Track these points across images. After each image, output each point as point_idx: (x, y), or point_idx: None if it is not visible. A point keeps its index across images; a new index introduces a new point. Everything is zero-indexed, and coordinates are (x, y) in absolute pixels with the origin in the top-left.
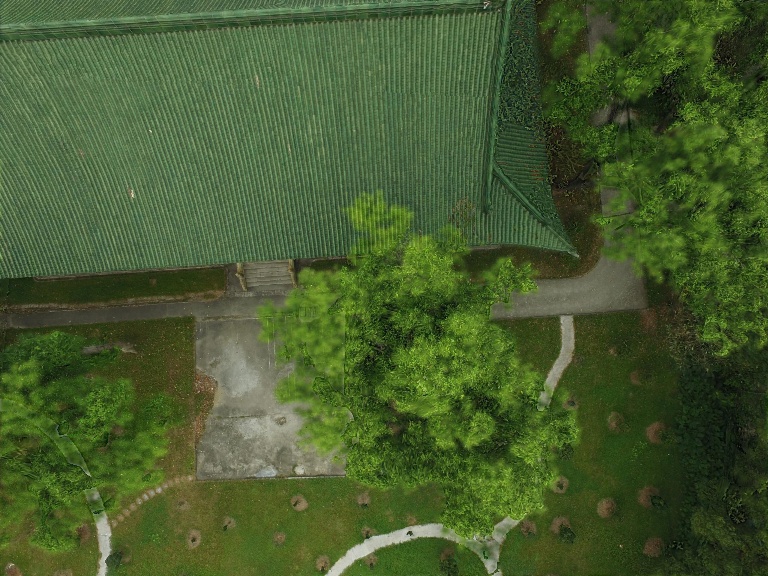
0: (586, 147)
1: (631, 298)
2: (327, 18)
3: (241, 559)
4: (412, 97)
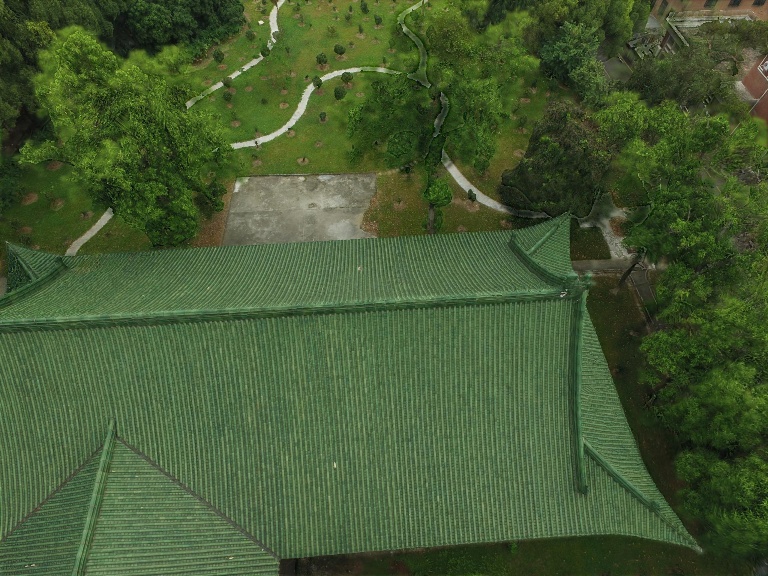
0: None
1: (2, 286)
2: None
3: (345, 135)
4: None
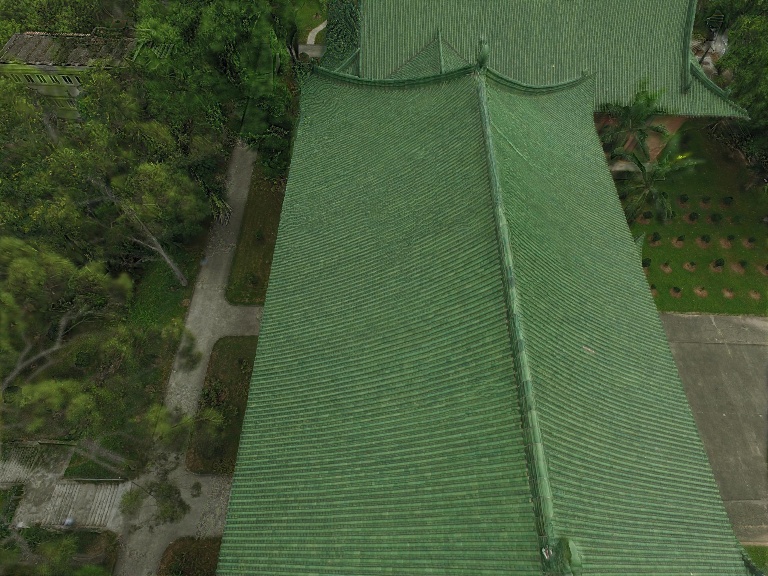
0: None
1: None
2: None
3: None
4: None
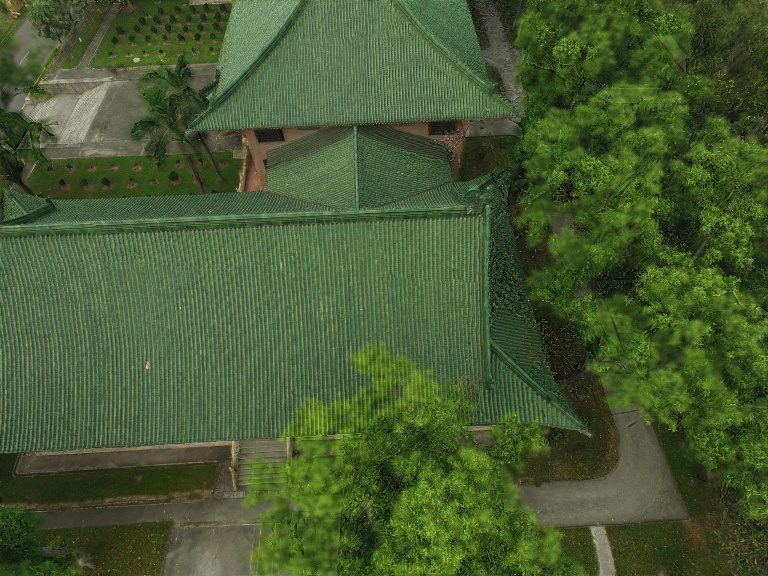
0: (572, 317)
1: (666, 505)
2: (343, 220)
3: None
4: (412, 282)
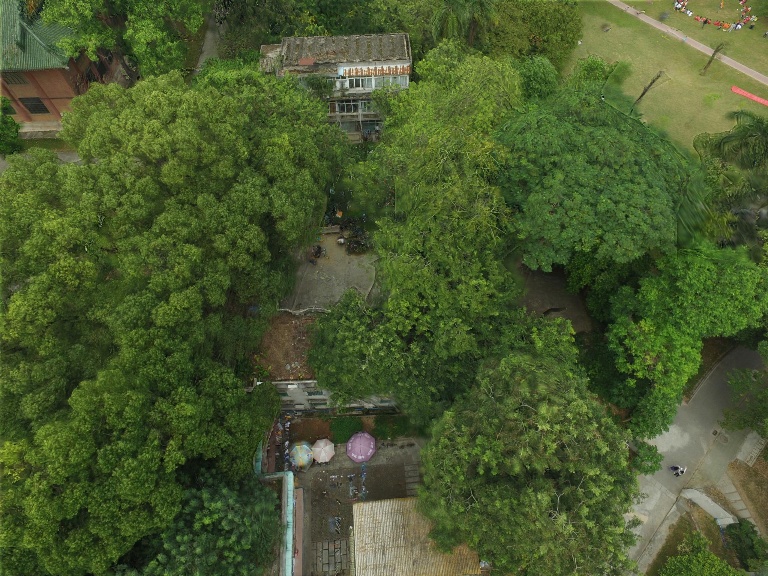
0: None
1: None
2: None
3: None
4: None
